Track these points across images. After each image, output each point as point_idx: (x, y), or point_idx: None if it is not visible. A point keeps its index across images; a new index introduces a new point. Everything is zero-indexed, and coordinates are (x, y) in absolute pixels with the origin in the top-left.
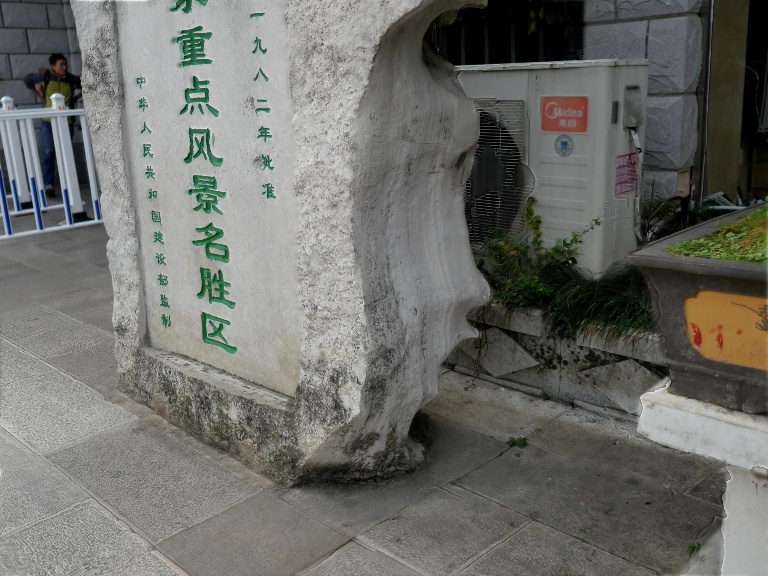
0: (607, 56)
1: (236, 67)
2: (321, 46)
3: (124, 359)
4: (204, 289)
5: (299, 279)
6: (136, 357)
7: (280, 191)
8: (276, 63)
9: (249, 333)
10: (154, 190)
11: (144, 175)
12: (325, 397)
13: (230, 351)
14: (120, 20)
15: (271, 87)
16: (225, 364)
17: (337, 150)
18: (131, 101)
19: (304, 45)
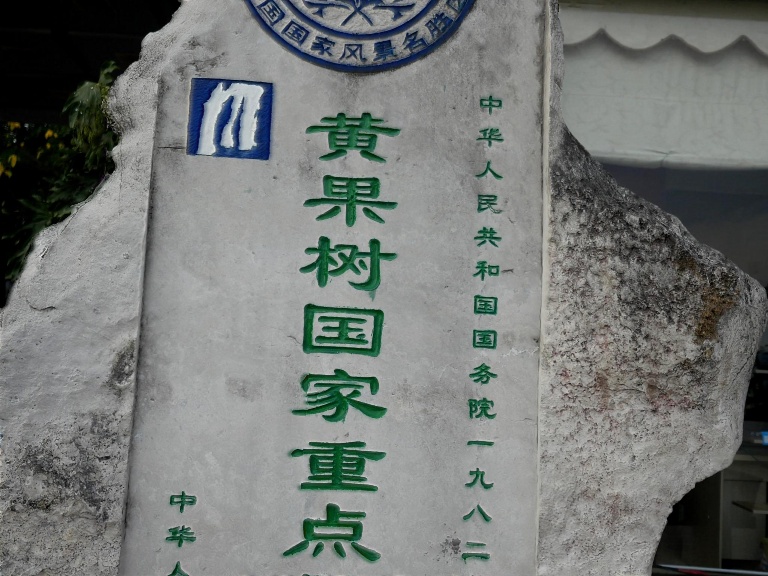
0: None
1: (431, 500)
2: (598, 492)
3: None
4: None
5: None
6: None
7: None
8: (507, 501)
9: None
10: None
11: None
12: None
13: None
14: (142, 406)
15: (497, 529)
16: None
17: None
18: (142, 529)
19: (572, 488)
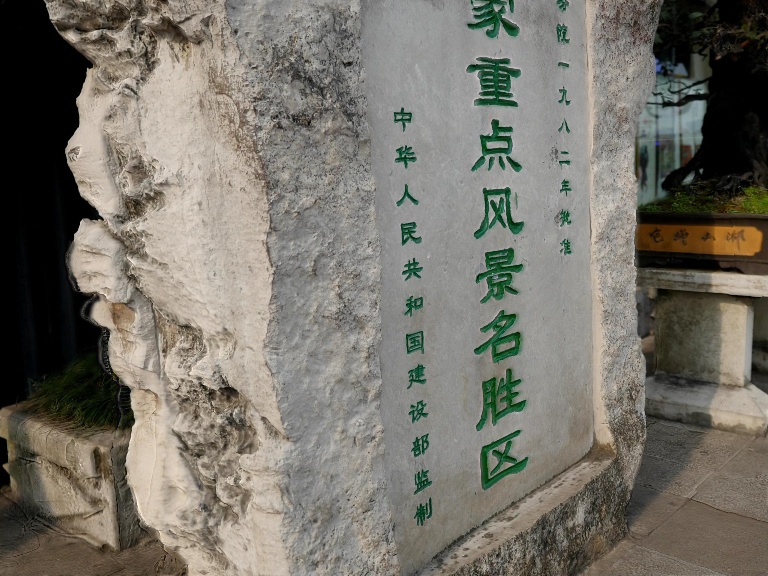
0: None
1: (544, 115)
2: None
3: None
4: (484, 412)
5: None
6: None
7: (576, 244)
8: None
9: (542, 425)
10: (417, 297)
11: (400, 277)
12: (630, 418)
13: (518, 470)
14: (361, 5)
15: (574, 139)
16: (515, 492)
17: (628, 194)
18: (376, 151)
19: None
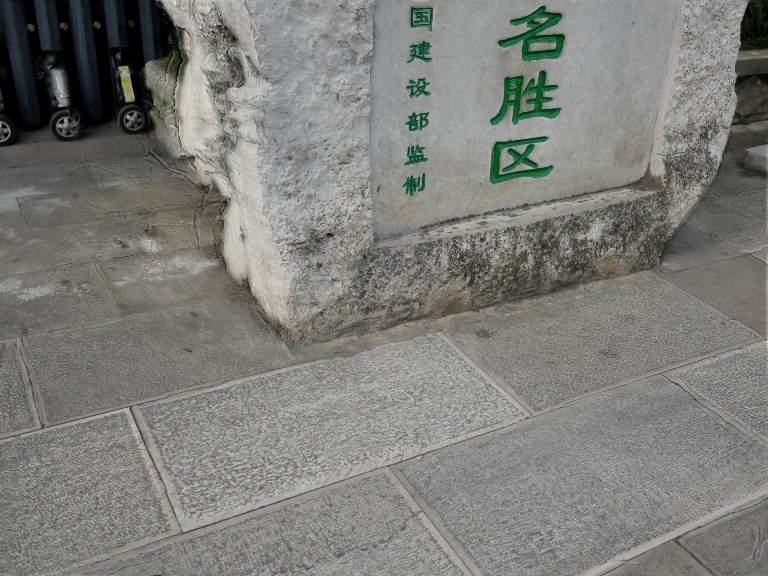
0: None
1: None
2: None
3: (323, 288)
4: (504, 108)
5: (682, 46)
6: (360, 268)
7: None
8: None
9: (579, 138)
10: None
11: None
12: (696, 157)
13: (539, 175)
14: None
15: None
16: (530, 195)
17: None
18: None
19: None
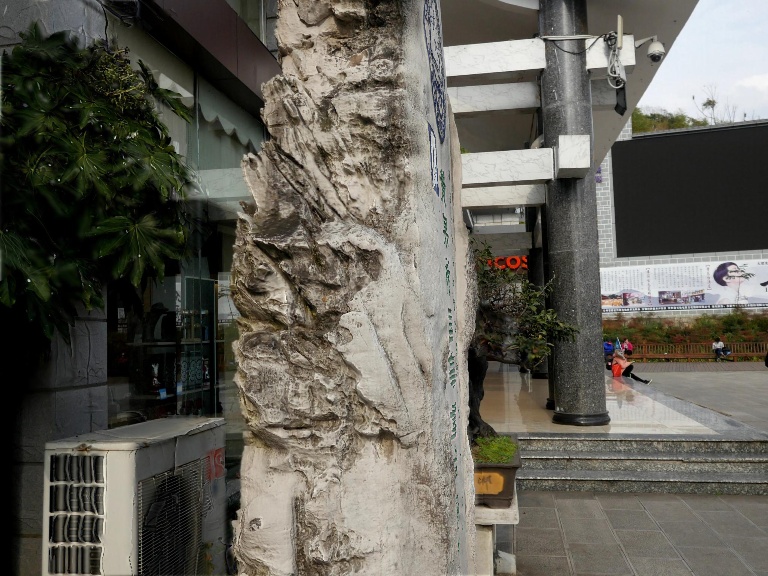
0: (156, 416)
1: None
2: None
3: None
4: None
5: None
6: None
7: None
8: None
9: None
10: None
11: None
12: None
13: None
14: None
15: None
16: None
17: (472, 472)
18: None
19: None
